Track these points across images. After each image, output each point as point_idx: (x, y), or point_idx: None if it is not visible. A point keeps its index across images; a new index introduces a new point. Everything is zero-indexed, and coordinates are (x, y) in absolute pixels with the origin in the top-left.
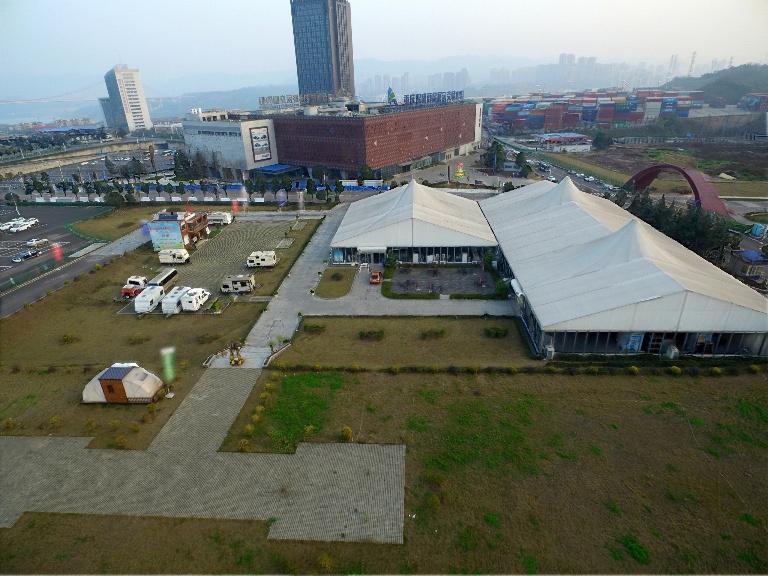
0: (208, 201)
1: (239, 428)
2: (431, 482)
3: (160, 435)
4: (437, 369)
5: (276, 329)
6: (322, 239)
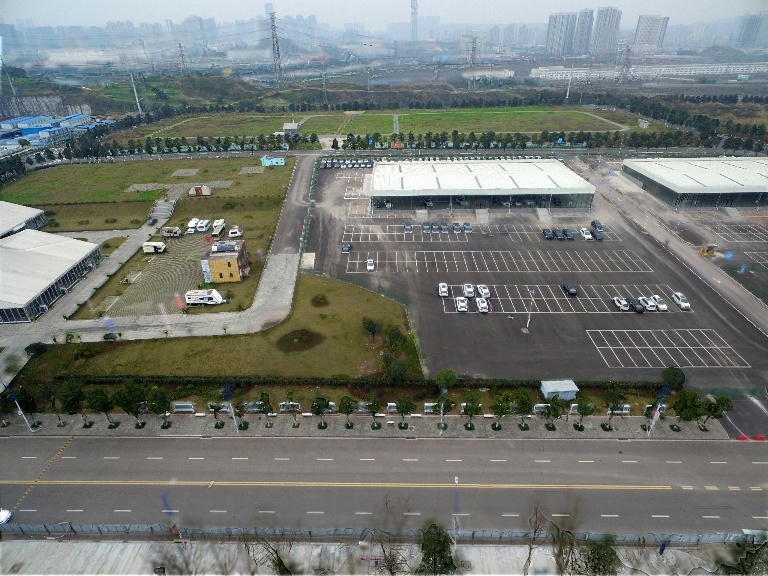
0: (244, 377)
1: None
2: None
3: None
4: None
5: None
6: (94, 283)
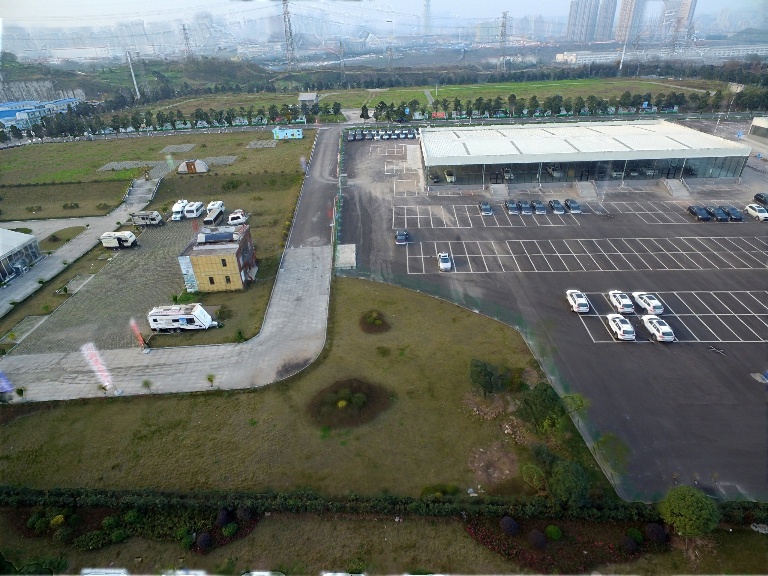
0: (243, 494)
1: None
2: None
3: None
4: None
5: None
6: (16, 294)
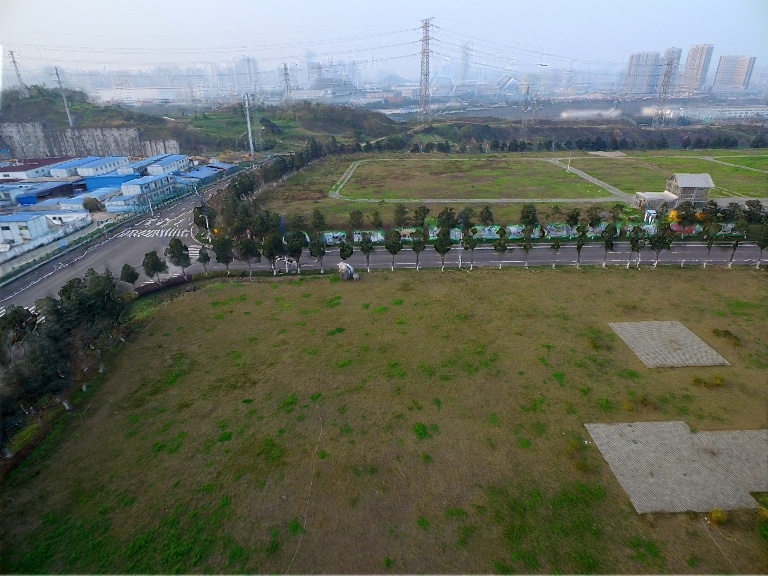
0: None
1: None
2: (586, 466)
3: None
4: None
5: None
6: None
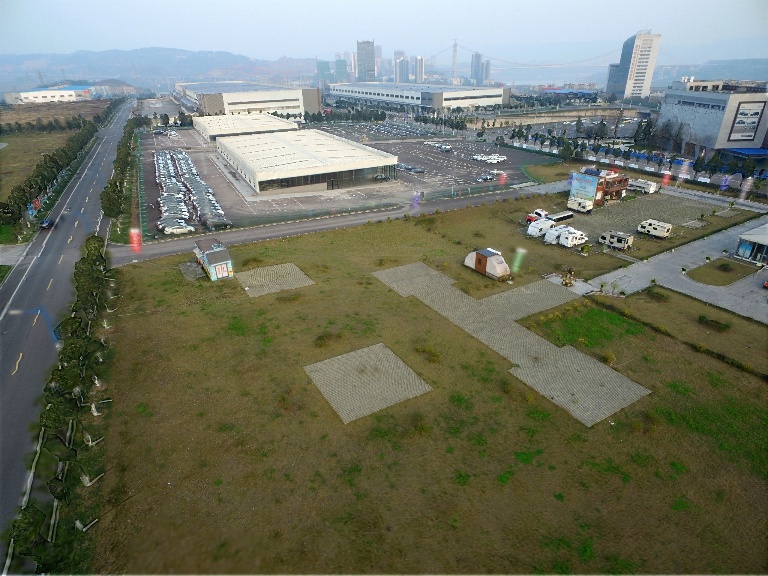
0: (646, 170)
1: (537, 318)
2: (648, 418)
3: (490, 297)
4: (750, 369)
5: (621, 282)
6: (743, 232)
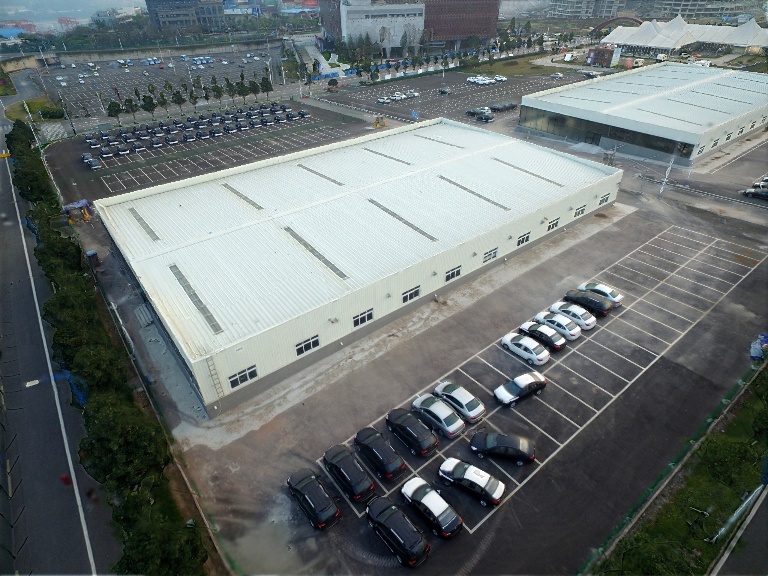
0: (502, 58)
1: None
2: None
3: None
4: None
5: None
6: None
